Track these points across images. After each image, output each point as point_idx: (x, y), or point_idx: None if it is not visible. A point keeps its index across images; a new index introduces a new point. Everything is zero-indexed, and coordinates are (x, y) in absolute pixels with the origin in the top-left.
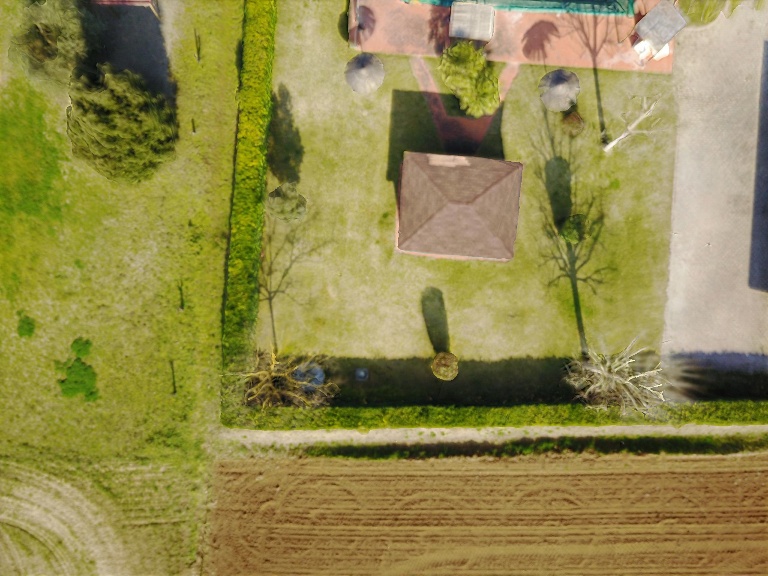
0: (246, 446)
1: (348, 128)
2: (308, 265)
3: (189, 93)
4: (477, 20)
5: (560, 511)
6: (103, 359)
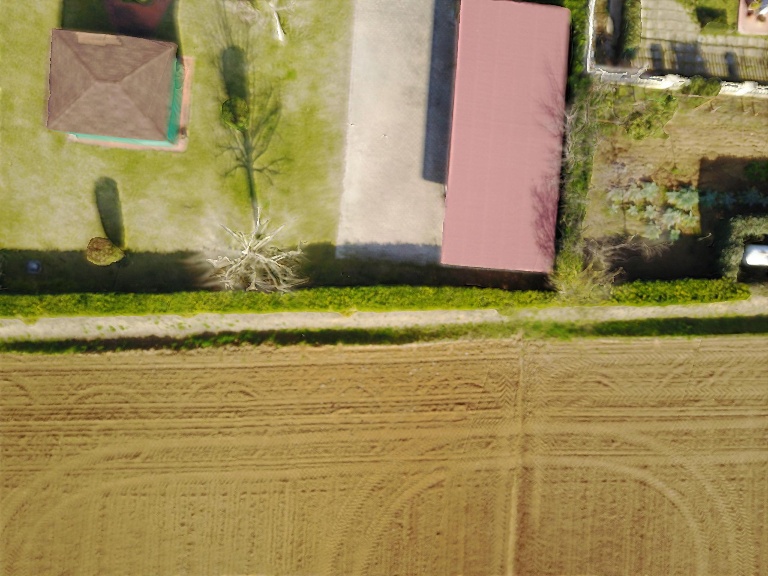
0: None
1: (19, 13)
2: None
3: None
4: None
5: (236, 403)
6: None
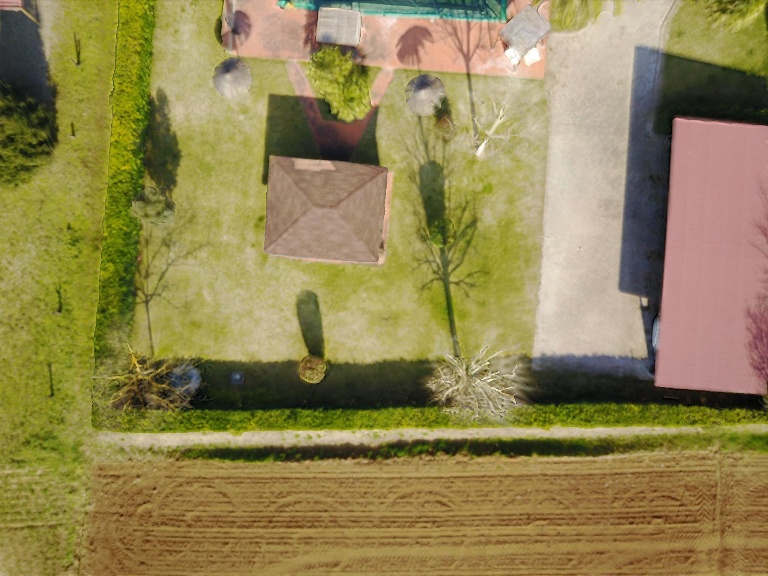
0: (124, 449)
1: (224, 132)
2: (184, 268)
3: (68, 97)
4: (344, 25)
5: (433, 513)
6: None
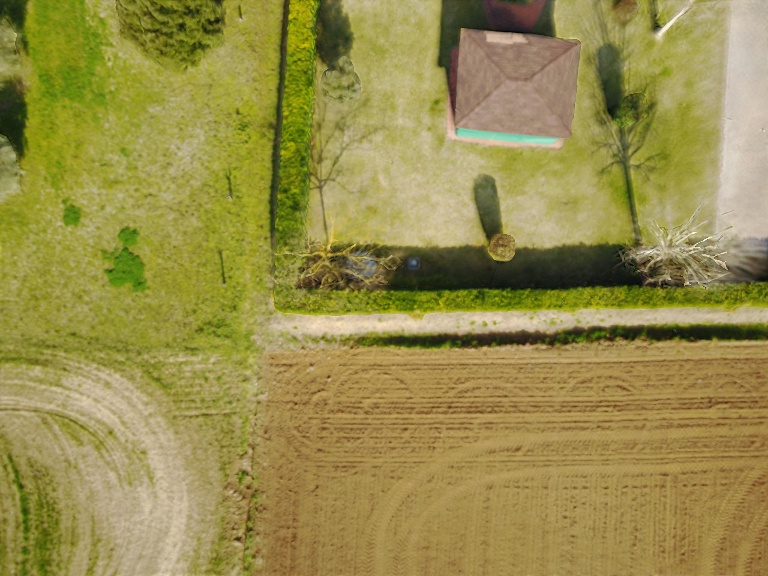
0: (296, 338)
1: (399, 13)
2: (359, 152)
3: None
4: None
5: (613, 397)
6: (151, 249)
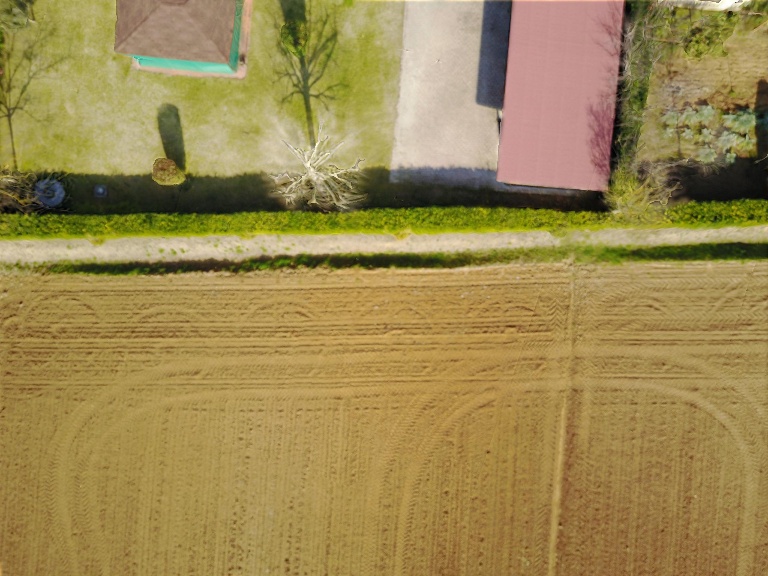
0: None
1: None
2: (45, 81)
3: None
4: None
5: (292, 323)
6: None
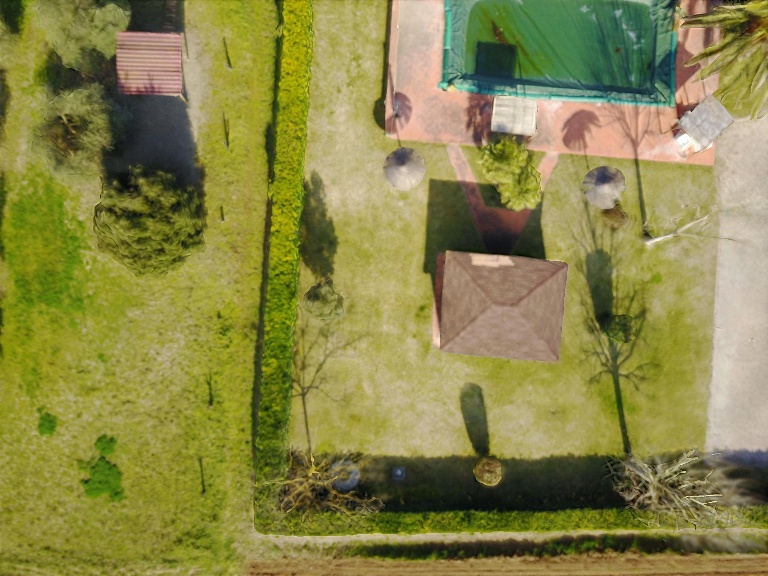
0: (278, 546)
1: (384, 218)
2: (343, 360)
3: (218, 179)
4: (520, 114)
5: None
6: (128, 458)
